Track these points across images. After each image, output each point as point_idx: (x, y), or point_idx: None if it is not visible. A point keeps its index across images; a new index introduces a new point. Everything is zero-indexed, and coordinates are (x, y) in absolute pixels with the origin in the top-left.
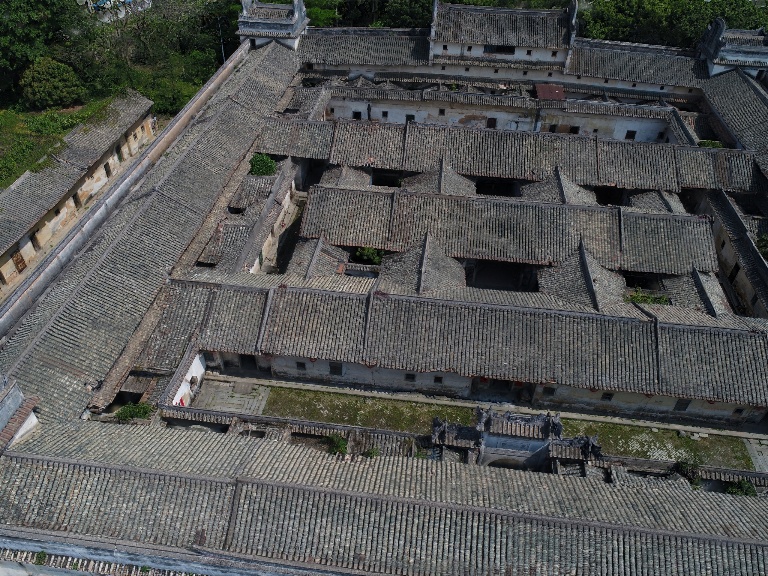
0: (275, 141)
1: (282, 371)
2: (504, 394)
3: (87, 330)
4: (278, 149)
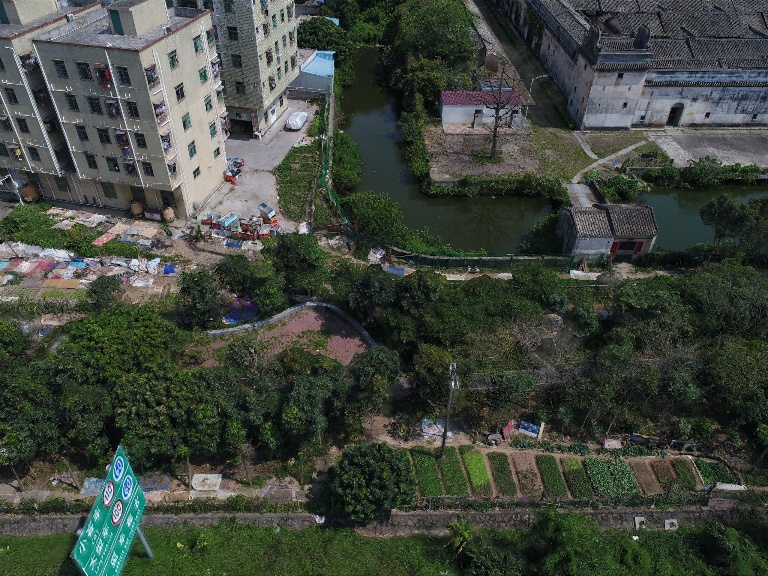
0: (569, 4)
1: None
2: None
3: None
4: (572, 7)
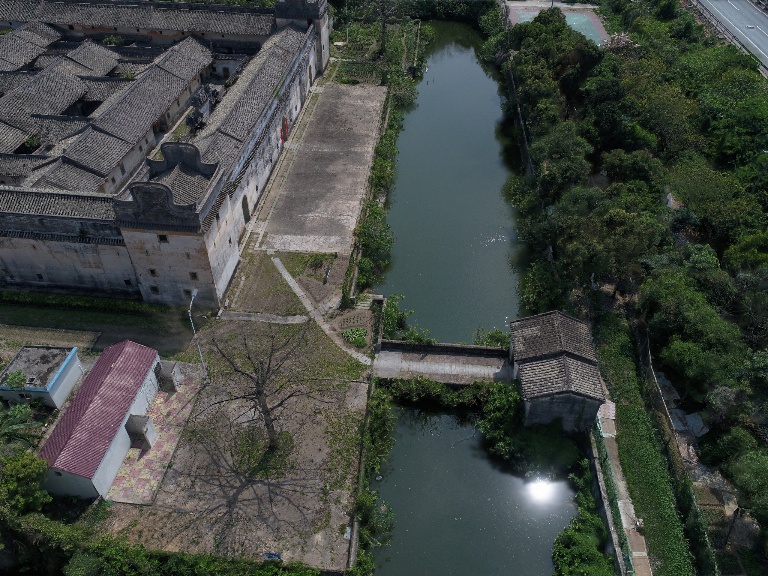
0: None
1: (110, 193)
2: (159, 135)
3: None
4: None
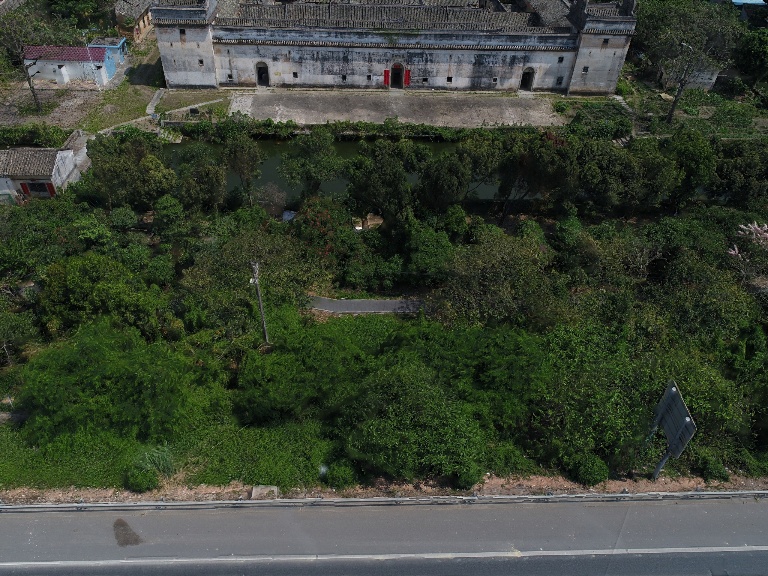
0: None
1: None
2: None
3: (220, 5)
4: None
